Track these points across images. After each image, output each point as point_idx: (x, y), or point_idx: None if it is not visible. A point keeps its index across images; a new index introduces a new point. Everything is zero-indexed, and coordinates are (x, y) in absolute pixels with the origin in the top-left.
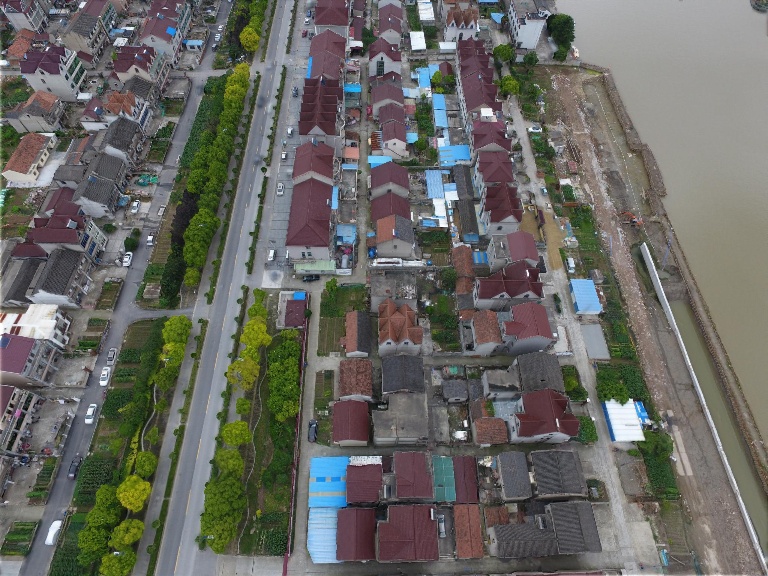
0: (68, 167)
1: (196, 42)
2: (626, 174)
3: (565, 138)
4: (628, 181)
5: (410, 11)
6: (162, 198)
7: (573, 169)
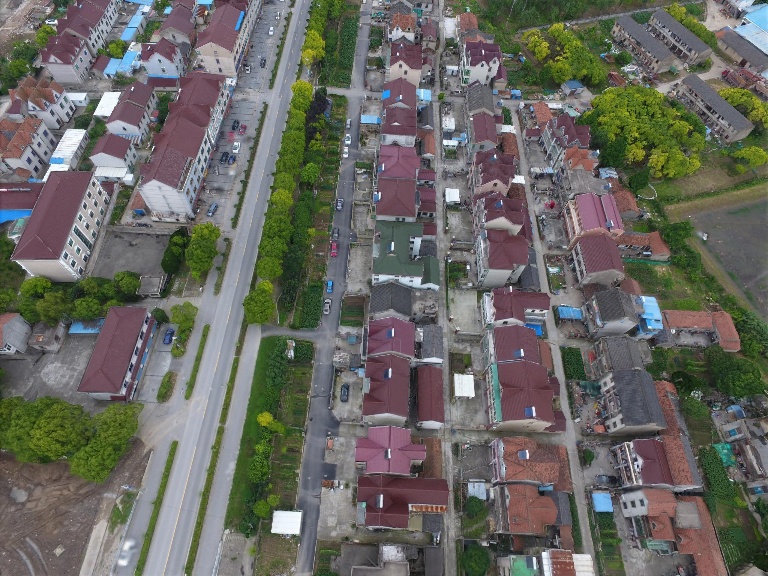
0: (426, 0)
1: (367, 119)
2: (1, 6)
3: (29, 22)
4: (5, 2)
5: (88, 164)
6: (366, 8)
7: (47, 1)
